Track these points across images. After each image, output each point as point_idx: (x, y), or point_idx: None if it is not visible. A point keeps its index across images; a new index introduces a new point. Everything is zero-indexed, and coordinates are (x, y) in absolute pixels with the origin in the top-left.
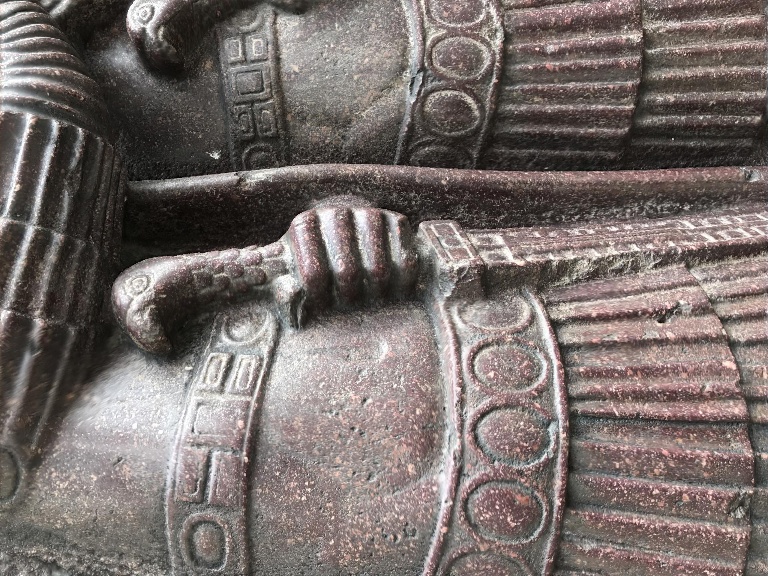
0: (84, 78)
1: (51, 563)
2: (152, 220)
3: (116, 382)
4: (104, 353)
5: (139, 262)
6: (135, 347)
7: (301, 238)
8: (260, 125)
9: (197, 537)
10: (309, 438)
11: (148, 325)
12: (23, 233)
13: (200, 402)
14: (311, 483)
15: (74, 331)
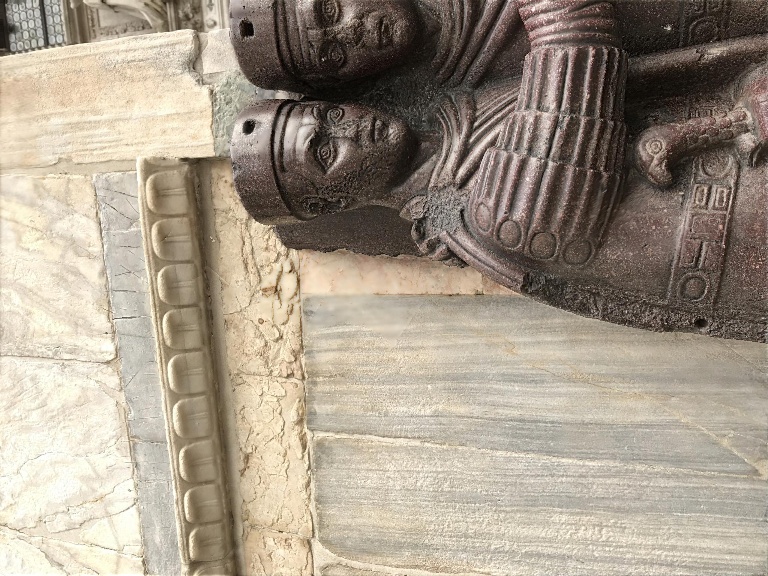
0: (609, 7)
1: (596, 293)
2: (631, 87)
3: (638, 202)
4: (626, 185)
5: (648, 130)
6: (644, 180)
7: (765, 111)
8: (710, 4)
9: (689, 284)
10: (763, 235)
11: (665, 172)
12: (594, 124)
13: (694, 214)
14: (763, 259)
15: (619, 176)
